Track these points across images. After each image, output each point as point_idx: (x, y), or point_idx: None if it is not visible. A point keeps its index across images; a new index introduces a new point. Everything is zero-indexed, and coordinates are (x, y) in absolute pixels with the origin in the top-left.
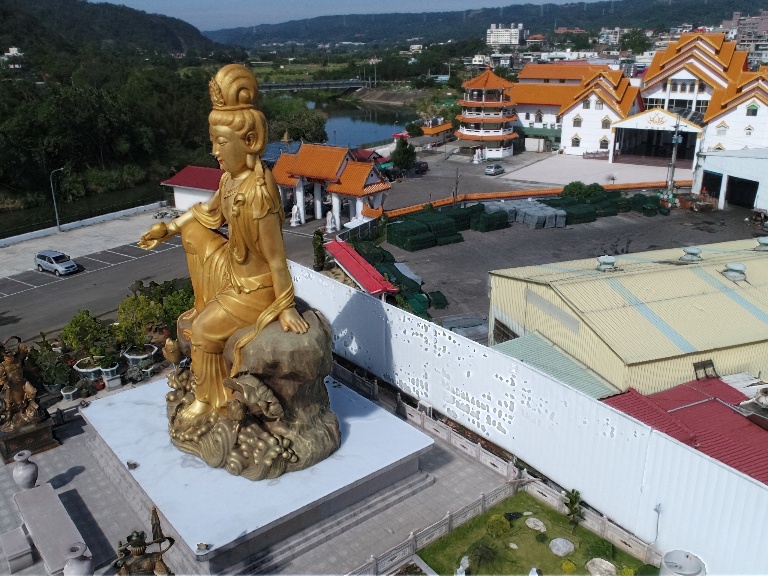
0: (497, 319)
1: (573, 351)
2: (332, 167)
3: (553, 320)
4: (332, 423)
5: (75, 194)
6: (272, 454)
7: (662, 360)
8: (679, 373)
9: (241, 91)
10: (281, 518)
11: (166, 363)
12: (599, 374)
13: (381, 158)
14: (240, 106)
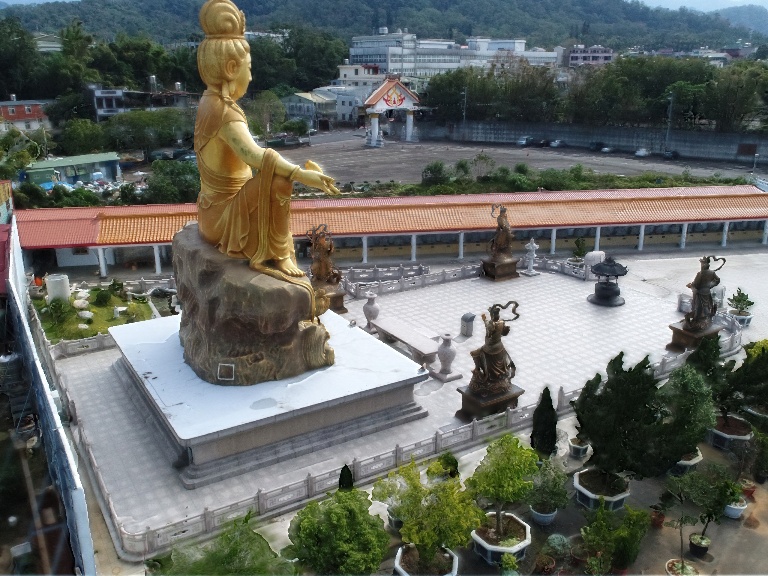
0: None
1: None
2: None
3: None
4: None
5: None
6: None
7: None
8: None
9: None
10: None
11: (379, 572)
12: None
13: None
14: None
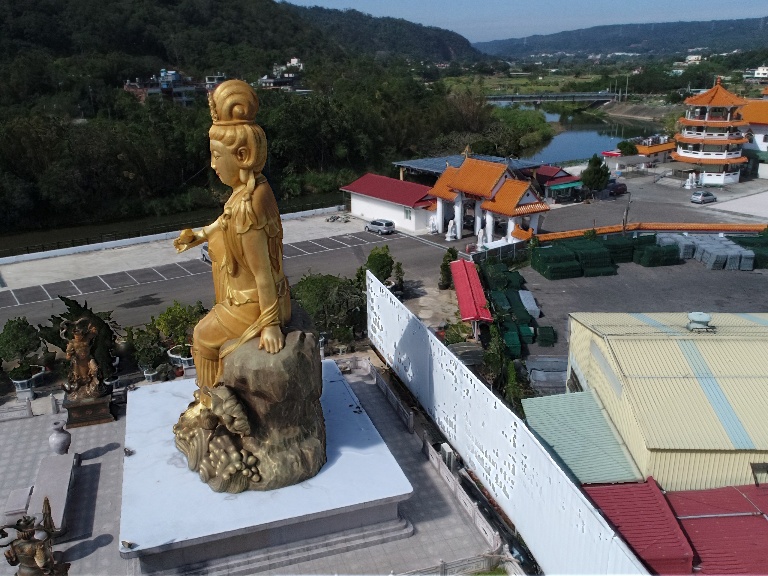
0: (572, 368)
1: (615, 420)
2: (488, 183)
3: (605, 379)
4: (310, 449)
5: (292, 193)
6: (230, 469)
7: (701, 451)
8: (729, 472)
9: (235, 107)
10: (213, 535)
11: None
12: (631, 453)
13: (570, 177)
14: (233, 121)
